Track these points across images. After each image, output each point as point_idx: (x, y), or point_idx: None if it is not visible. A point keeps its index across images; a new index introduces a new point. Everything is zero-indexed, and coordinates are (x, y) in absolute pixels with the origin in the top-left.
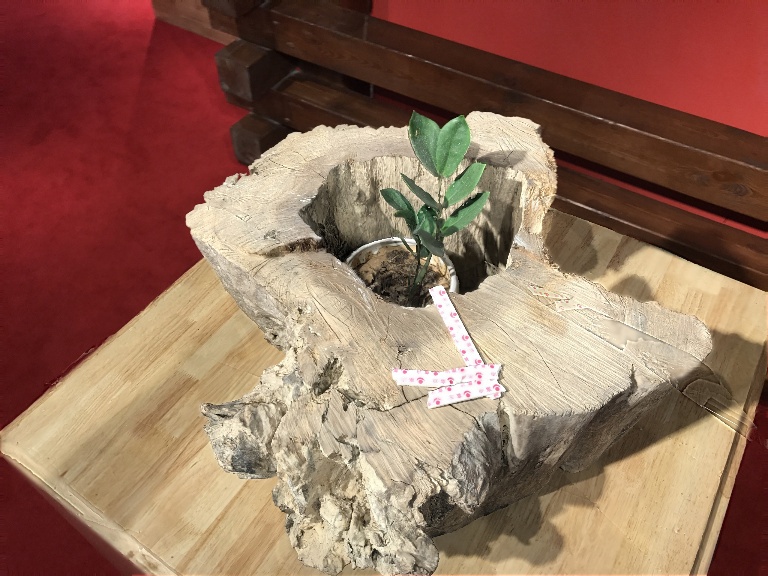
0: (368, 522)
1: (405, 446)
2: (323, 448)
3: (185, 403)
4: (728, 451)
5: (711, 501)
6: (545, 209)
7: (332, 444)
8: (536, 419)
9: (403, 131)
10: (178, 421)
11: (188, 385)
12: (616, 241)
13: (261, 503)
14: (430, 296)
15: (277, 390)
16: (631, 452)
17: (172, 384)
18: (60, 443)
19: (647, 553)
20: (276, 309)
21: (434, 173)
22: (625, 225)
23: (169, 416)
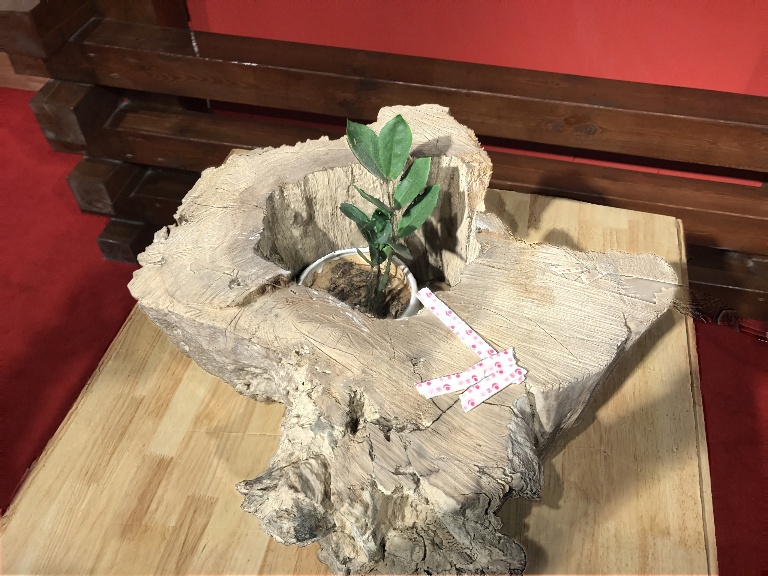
0: (441, 544)
1: (460, 457)
2: (384, 486)
3: (168, 486)
4: (688, 365)
5: (692, 413)
6: (485, 188)
7: (391, 479)
8: (562, 390)
9: (322, 142)
10: (167, 508)
11: (163, 466)
12: (526, 201)
13: (291, 562)
14: (390, 300)
15: (311, 443)
16: (612, 392)
17: (145, 471)
18: None
19: (660, 478)
20: (261, 358)
21: (382, 178)
22: (527, 185)
23: (155, 506)
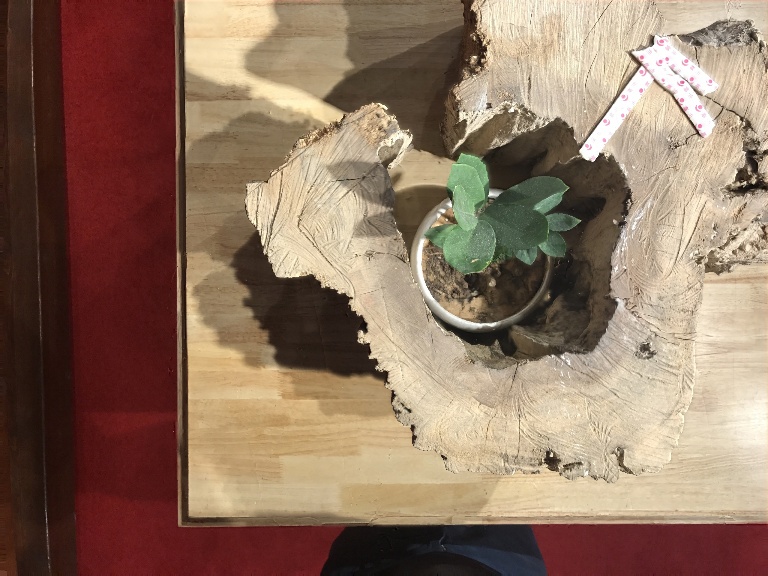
0: None
1: (763, 86)
2: None
3: None
4: None
5: None
6: None
7: None
8: None
9: (374, 336)
10: None
11: None
12: (202, 106)
13: None
14: None
15: None
16: None
17: None
18: (765, 459)
19: None
20: None
21: (484, 224)
22: None
23: None
